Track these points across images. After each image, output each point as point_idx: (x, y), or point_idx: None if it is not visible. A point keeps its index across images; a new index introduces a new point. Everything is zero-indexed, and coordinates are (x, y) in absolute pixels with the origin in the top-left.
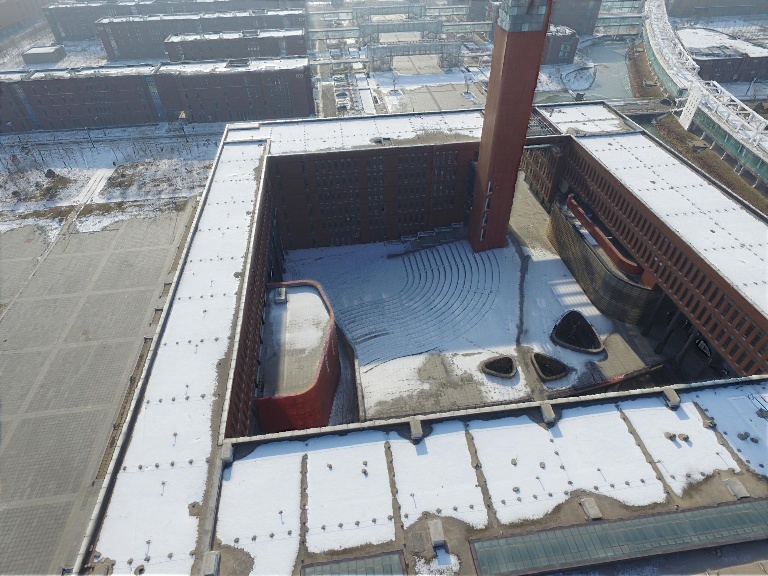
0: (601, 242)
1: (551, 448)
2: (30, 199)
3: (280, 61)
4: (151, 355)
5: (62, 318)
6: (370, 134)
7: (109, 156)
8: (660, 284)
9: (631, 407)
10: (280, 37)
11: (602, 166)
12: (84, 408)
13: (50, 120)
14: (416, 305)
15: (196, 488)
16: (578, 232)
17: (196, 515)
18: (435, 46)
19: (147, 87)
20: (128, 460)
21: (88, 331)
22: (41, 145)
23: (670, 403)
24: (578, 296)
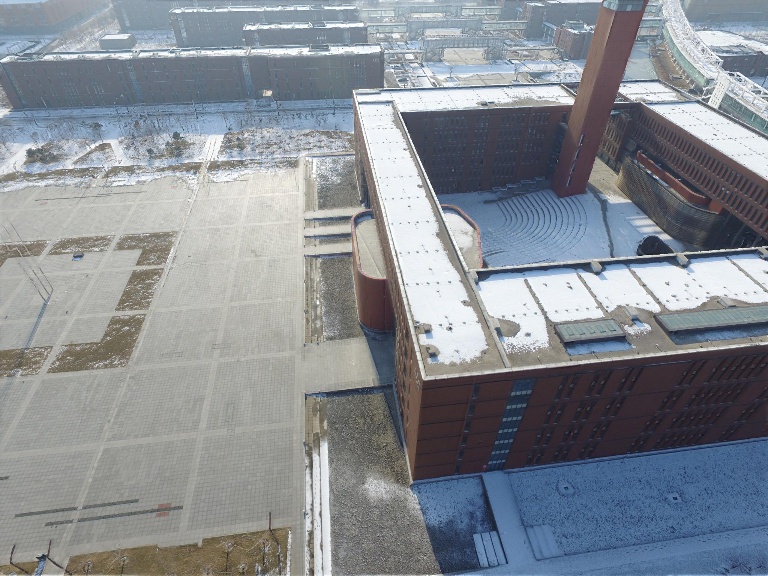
0: (672, 183)
1: (689, 277)
2: (160, 157)
3: (356, 47)
4: (389, 228)
5: (229, 241)
6: (475, 99)
7: (214, 125)
8: (727, 208)
9: (737, 258)
10: (346, 28)
11: (673, 123)
12: (276, 300)
13: (152, 95)
14: (520, 234)
15: (461, 294)
16: (651, 177)
17: (469, 306)
18: (482, 40)
19: (241, 67)
20: (407, 280)
21: (255, 250)
22: (149, 116)
23: (763, 256)
24: (652, 227)
